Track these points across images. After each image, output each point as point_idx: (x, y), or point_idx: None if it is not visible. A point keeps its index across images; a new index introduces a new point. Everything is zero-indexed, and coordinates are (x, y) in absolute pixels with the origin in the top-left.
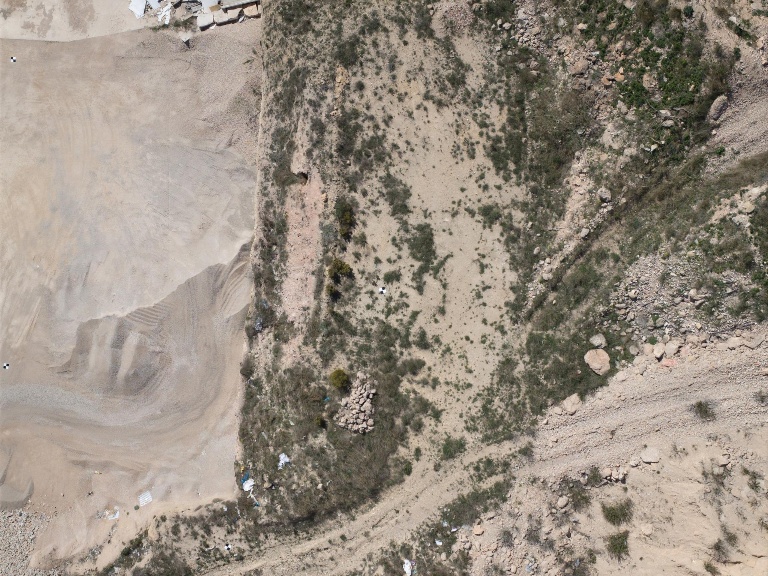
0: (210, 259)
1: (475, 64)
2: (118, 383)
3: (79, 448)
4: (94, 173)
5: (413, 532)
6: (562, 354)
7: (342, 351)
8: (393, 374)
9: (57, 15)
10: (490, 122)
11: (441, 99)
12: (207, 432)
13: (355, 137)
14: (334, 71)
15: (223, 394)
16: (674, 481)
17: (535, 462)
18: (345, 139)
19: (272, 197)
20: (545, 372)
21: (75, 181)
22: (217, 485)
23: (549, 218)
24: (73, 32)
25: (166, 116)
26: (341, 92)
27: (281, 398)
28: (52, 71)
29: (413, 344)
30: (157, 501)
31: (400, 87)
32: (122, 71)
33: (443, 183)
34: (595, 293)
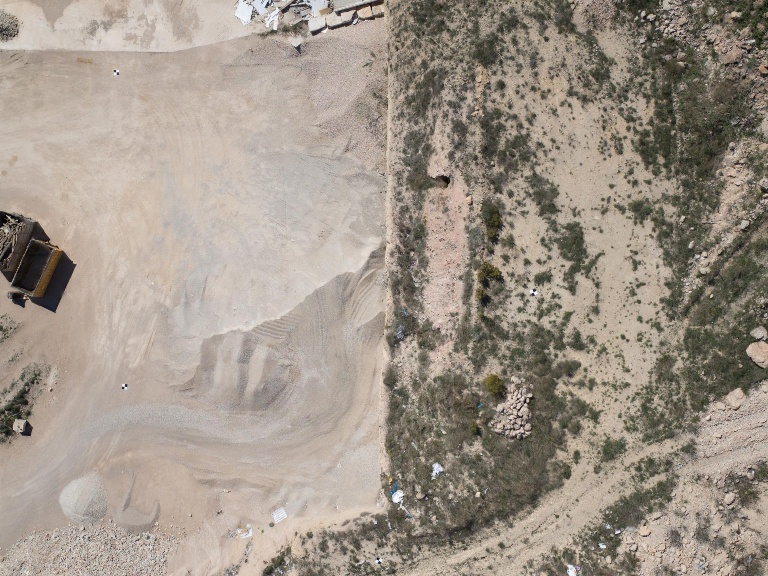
0: (334, 268)
1: (619, 58)
2: (246, 399)
3: (206, 467)
4: (206, 185)
5: (575, 536)
6: (722, 348)
7: (494, 356)
8: (548, 377)
9: (160, 25)
10: (637, 116)
11: (585, 95)
12: (341, 444)
13: (498, 137)
14: (473, 71)
15: (356, 405)
16: None
17: (698, 459)
18: (488, 140)
19: (407, 202)
20: (705, 368)
21: (187, 194)
22: (357, 498)
23: (702, 211)
24: (178, 42)
25: (278, 124)
26: (482, 92)
27: (431, 407)
28: (157, 83)
29: (567, 345)
30: (293, 517)
31: (542, 84)
32: (230, 80)
33: (591, 180)
34: (755, 285)
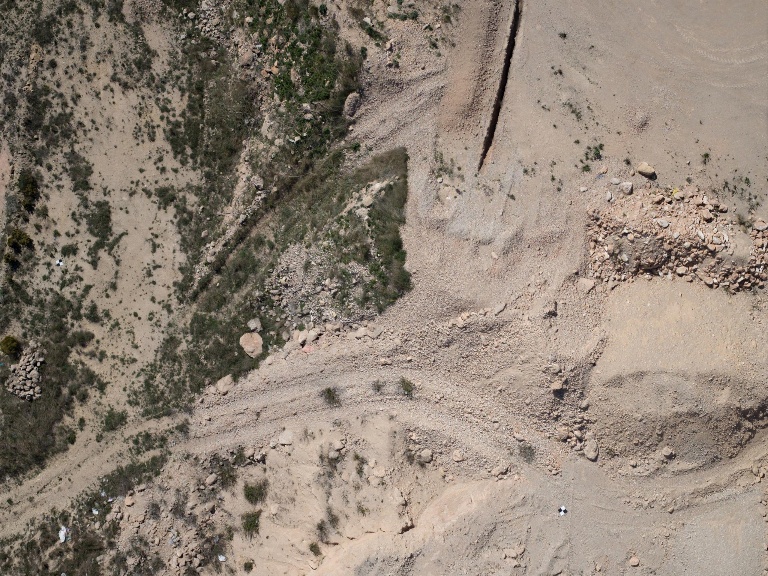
0: None
1: (161, 50)
2: None
3: None
4: None
5: (73, 500)
6: (222, 336)
7: (17, 319)
8: (63, 344)
9: None
10: (171, 107)
11: (127, 82)
12: None
13: (44, 113)
14: (30, 48)
15: None
16: (300, 463)
17: (190, 439)
18: (34, 114)
19: None
20: (205, 352)
21: None
22: None
23: (219, 203)
24: None
25: None
26: (34, 69)
27: None
28: None
29: (84, 317)
30: None
31: (90, 68)
32: None
33: (123, 163)
34: (254, 278)
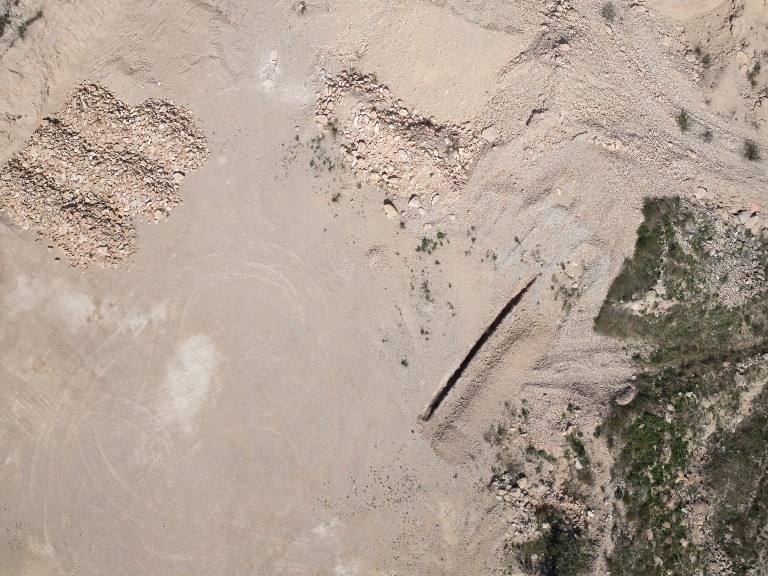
0: None
1: None
2: None
3: None
4: None
5: None
6: None
7: None
8: None
9: None
10: None
11: None
12: None
13: None
14: None
15: None
16: None
17: None
18: None
19: None
20: None
21: None
22: None
23: None
24: None
25: None
26: None
27: None
28: None
29: None
30: None
31: None
32: None
33: None
34: None
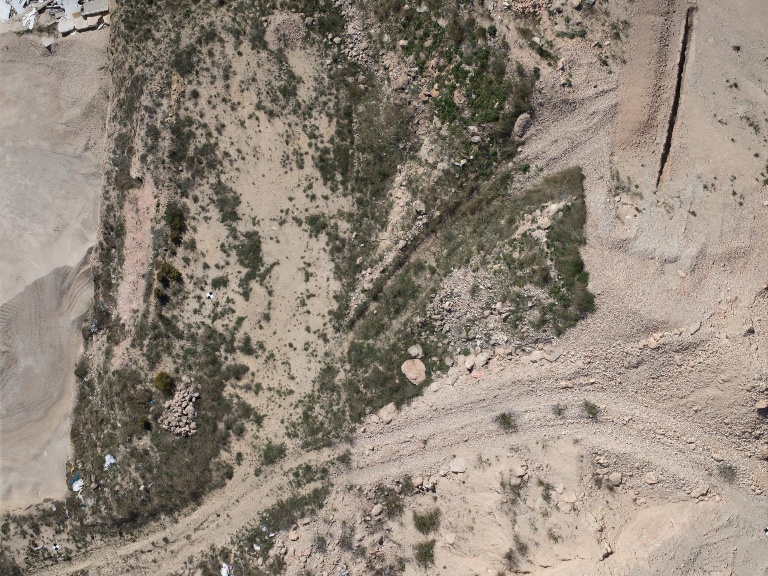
0: (61, 261)
1: (306, 76)
2: None
3: None
4: None
5: (233, 536)
6: (382, 363)
7: (169, 354)
8: (217, 378)
9: None
10: (319, 133)
11: (272, 109)
12: (50, 433)
13: (188, 144)
14: (170, 79)
15: (67, 395)
16: (477, 491)
17: (353, 469)
18: (178, 146)
19: (113, 201)
20: (364, 381)
21: None
22: (55, 485)
23: (373, 229)
24: None
25: (27, 119)
26: (176, 99)
27: (110, 399)
28: None
29: (238, 349)
30: None
31: (233, 96)
32: None
33: (272, 192)
34: (413, 304)
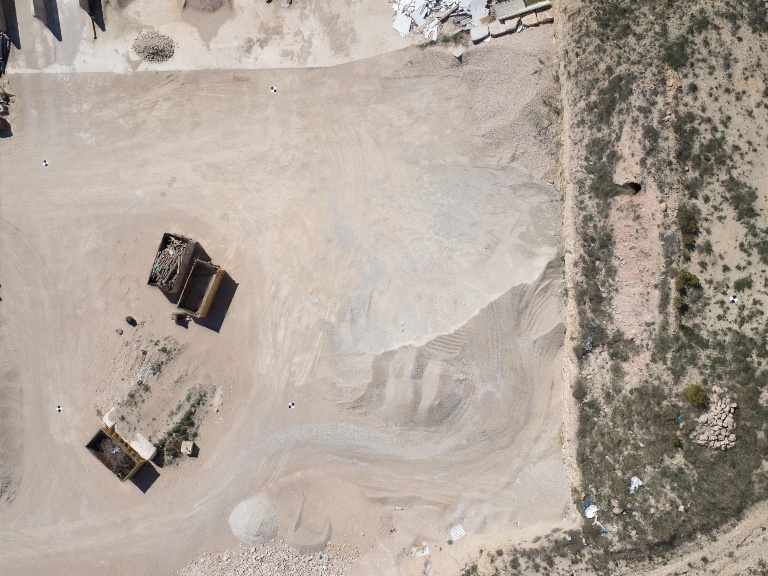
0: (505, 279)
1: None
2: (419, 415)
3: (378, 485)
4: (368, 200)
5: None
6: None
7: (694, 366)
8: (752, 386)
9: (317, 40)
10: None
11: None
12: (520, 459)
13: (692, 141)
14: (663, 74)
15: (534, 418)
16: None
17: None
18: (682, 144)
19: (591, 211)
20: None
21: (349, 210)
22: (540, 513)
23: None
24: (335, 56)
25: (441, 135)
26: (673, 96)
27: (627, 419)
28: (316, 98)
29: None
30: (472, 534)
31: (737, 86)
32: (390, 92)
33: None
34: None
